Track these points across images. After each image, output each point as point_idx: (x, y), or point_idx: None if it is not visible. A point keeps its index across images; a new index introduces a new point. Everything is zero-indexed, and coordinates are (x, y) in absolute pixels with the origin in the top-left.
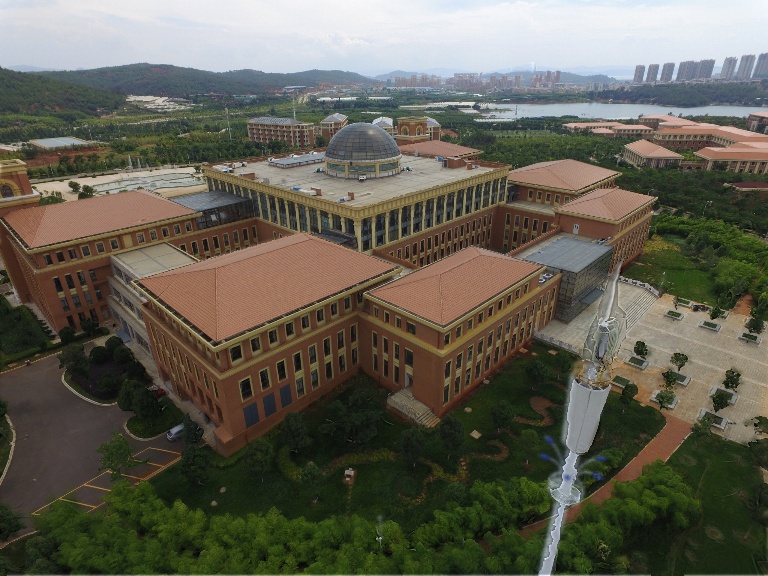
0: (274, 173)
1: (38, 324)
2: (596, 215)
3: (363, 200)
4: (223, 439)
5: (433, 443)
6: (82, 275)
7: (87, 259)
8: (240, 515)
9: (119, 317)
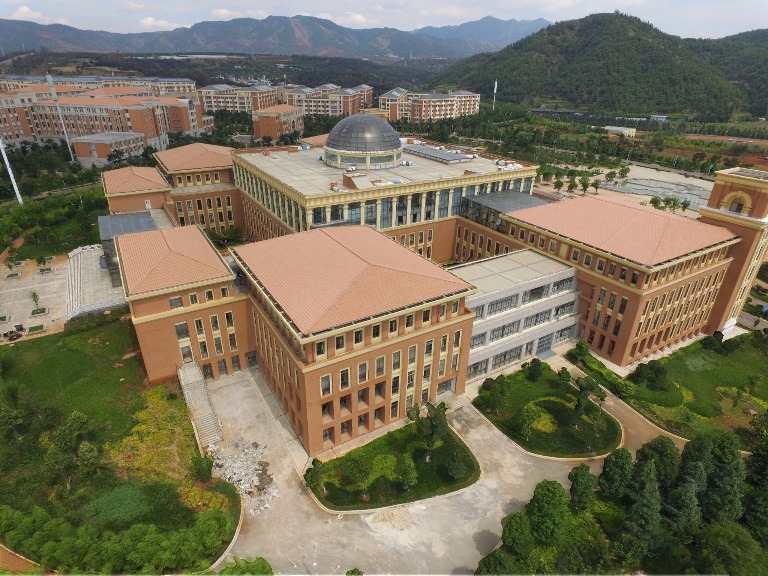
0: None
1: None
2: None
3: None
4: None
5: None
6: None
7: None
8: None
9: None
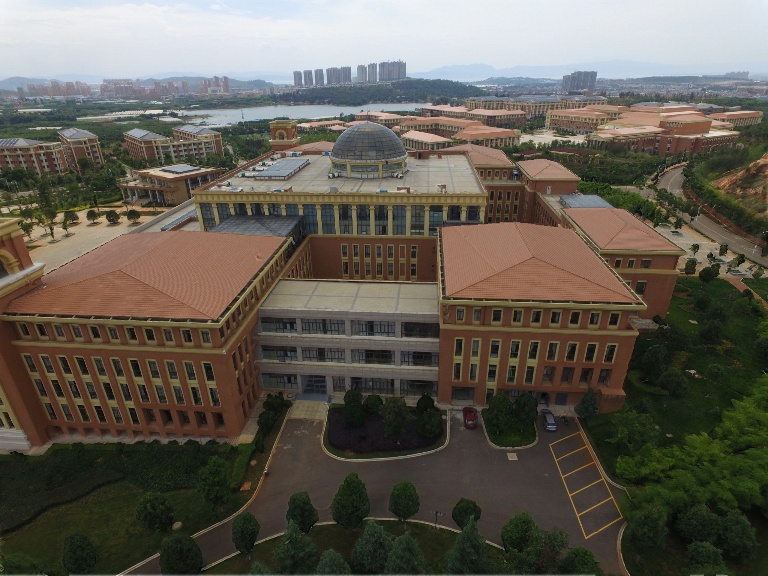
0: (291, 185)
1: (155, 444)
2: (563, 177)
3: (455, 190)
4: (621, 394)
5: (689, 336)
6: (244, 342)
7: (248, 319)
8: (695, 429)
9: (296, 378)
